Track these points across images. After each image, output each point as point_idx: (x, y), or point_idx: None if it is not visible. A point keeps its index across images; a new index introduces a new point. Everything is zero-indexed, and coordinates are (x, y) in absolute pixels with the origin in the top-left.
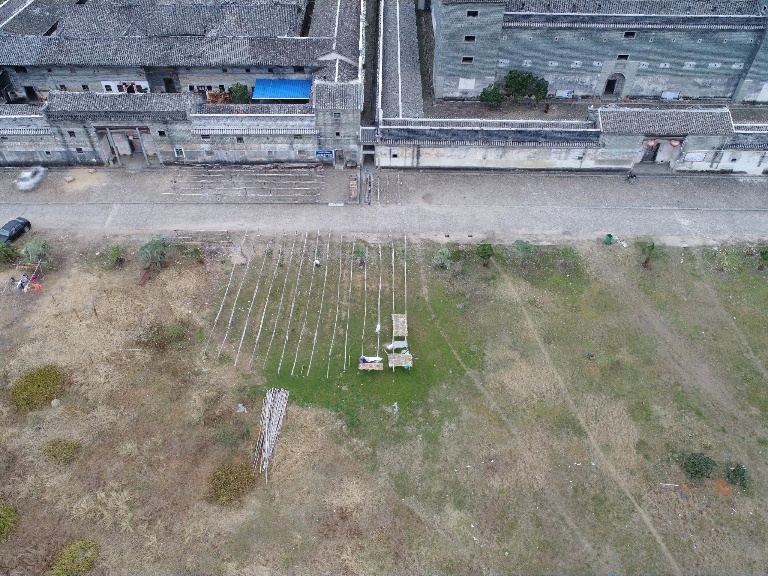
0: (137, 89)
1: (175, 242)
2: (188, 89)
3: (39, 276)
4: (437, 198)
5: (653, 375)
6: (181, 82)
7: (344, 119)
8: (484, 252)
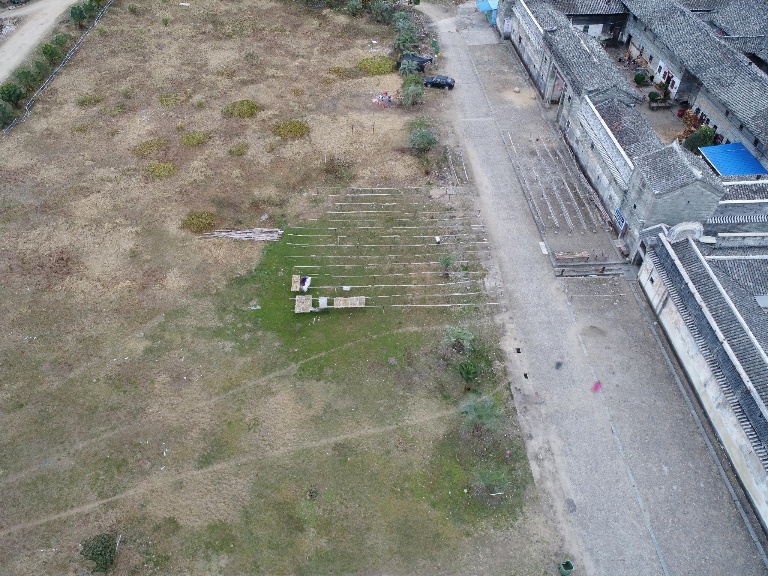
0: (672, 84)
1: (450, 155)
2: (695, 110)
3: (398, 106)
4: (598, 341)
5: (277, 573)
6: (697, 100)
7: (646, 195)
8: (463, 366)
